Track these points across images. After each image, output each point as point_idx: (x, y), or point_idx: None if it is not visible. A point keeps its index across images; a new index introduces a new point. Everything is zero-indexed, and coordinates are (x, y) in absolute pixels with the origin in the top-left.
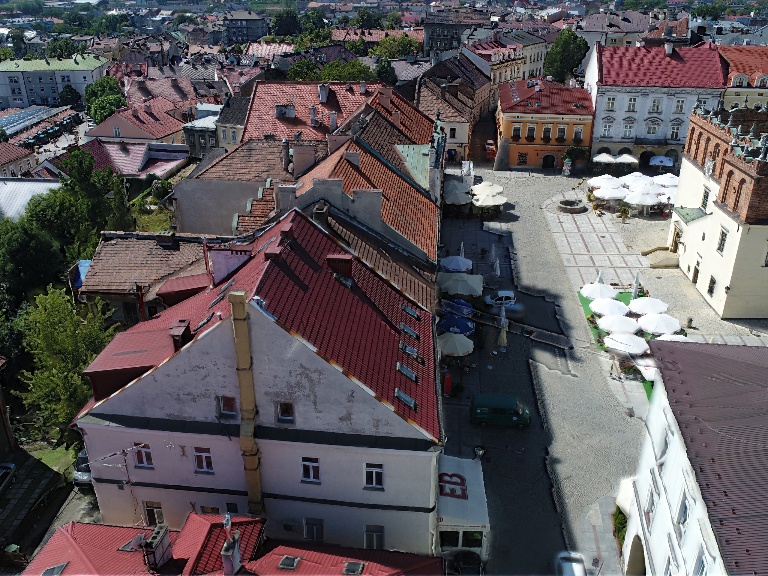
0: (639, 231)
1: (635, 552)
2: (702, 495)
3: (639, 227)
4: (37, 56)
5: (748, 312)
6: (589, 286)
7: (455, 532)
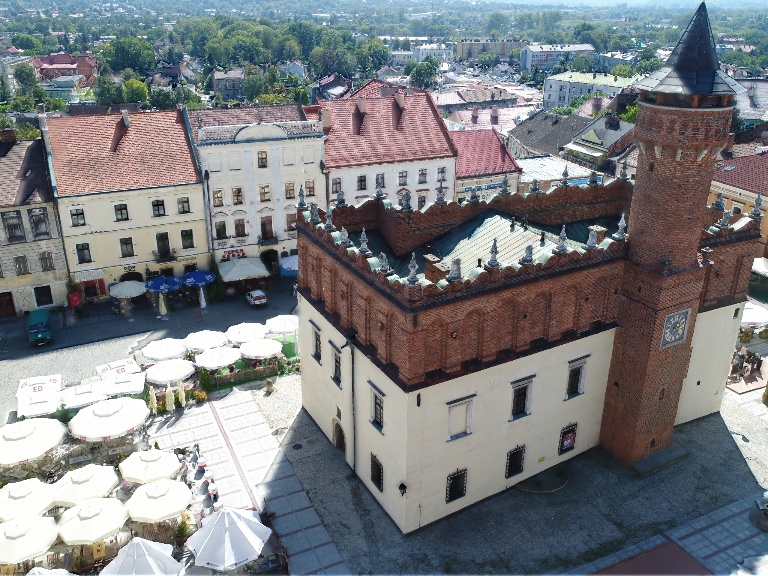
0: None
1: None
2: None
3: None
4: (626, 73)
5: (314, 412)
6: None
7: None
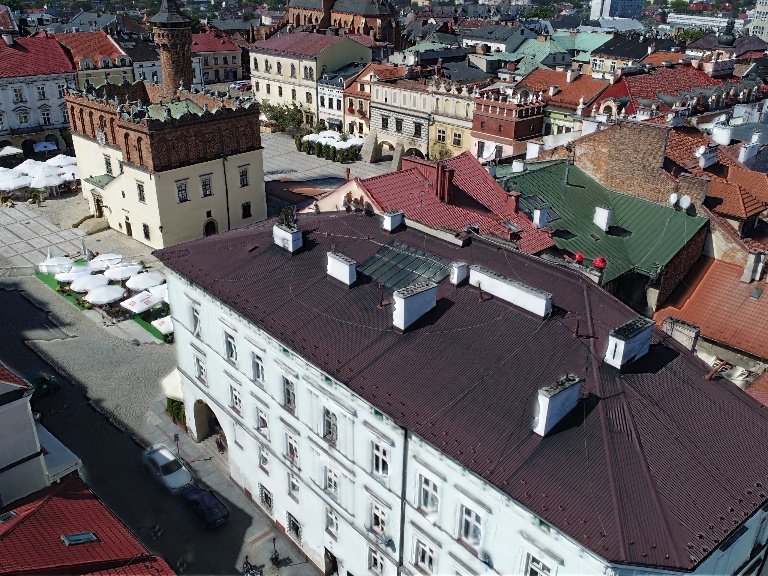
0: (59, 210)
1: (198, 418)
2: (244, 315)
3: (56, 207)
4: None
5: None
6: (45, 263)
7: (53, 483)
